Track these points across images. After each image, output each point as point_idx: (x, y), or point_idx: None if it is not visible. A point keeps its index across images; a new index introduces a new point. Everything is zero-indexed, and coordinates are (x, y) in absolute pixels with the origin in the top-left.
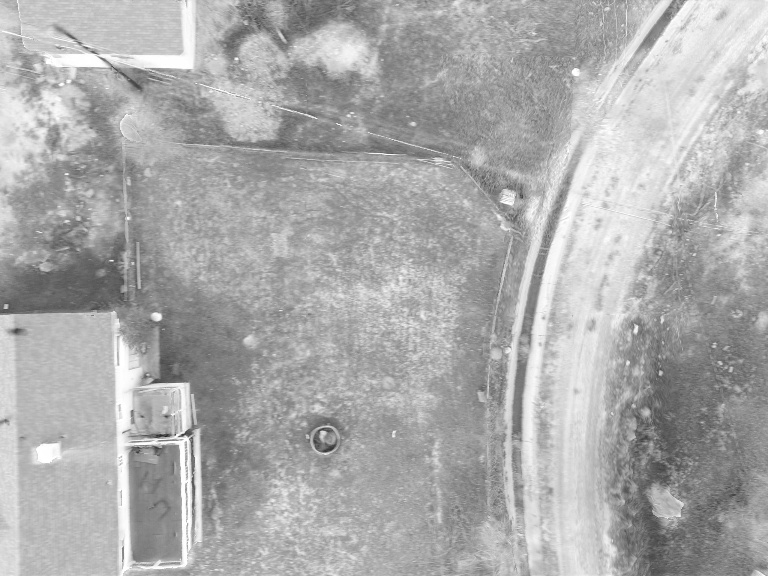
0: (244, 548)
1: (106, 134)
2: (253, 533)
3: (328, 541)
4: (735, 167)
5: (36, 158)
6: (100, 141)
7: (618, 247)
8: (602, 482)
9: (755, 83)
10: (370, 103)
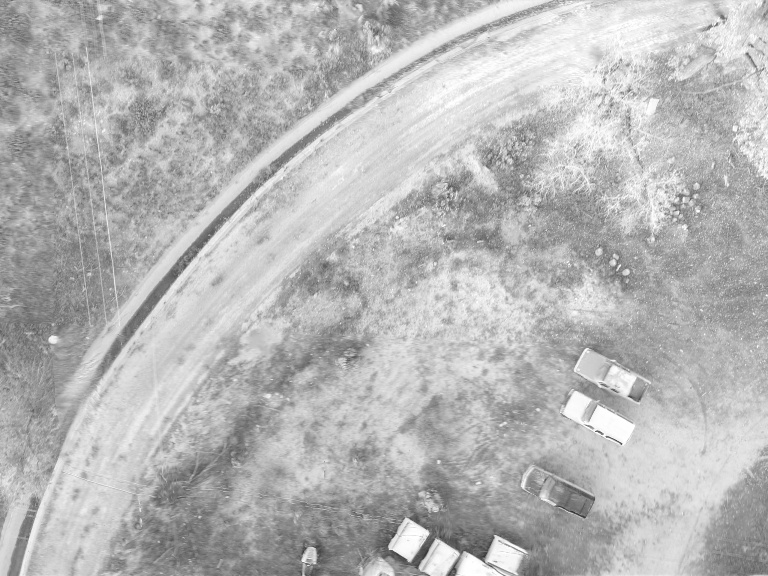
0: None
1: None
2: None
3: None
4: (243, 429)
5: None
6: None
7: (95, 519)
8: None
9: (251, 352)
10: None
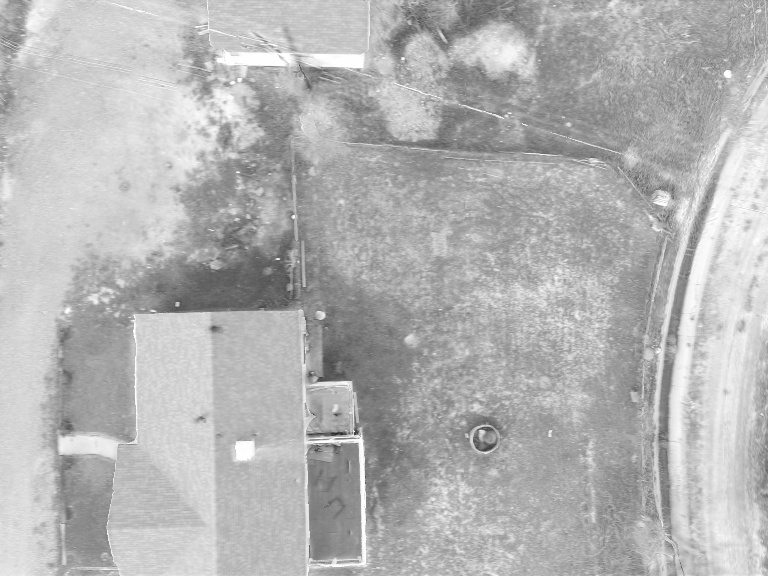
0: (405, 546)
1: (273, 133)
2: (414, 531)
3: (486, 540)
4: None
5: (208, 156)
6: (267, 139)
7: (767, 248)
8: (752, 482)
9: None
10: (527, 103)
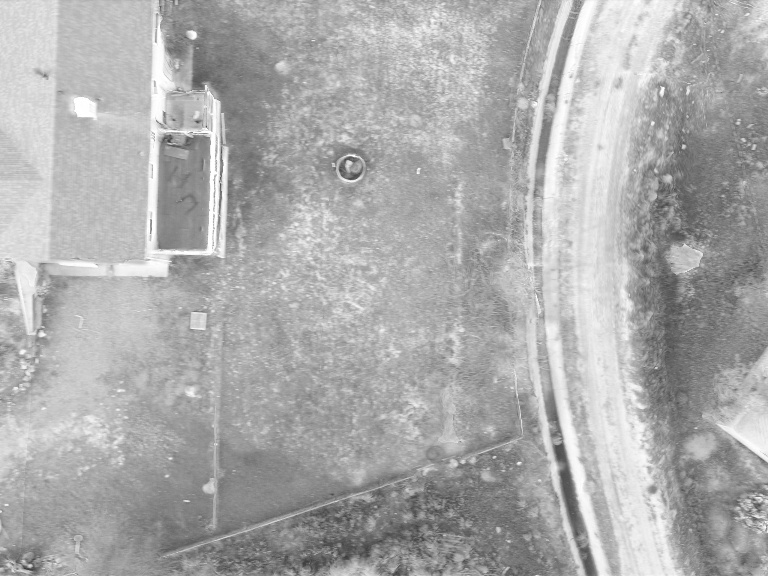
0: (266, 268)
1: None
2: (275, 254)
3: (349, 269)
4: None
5: None
6: None
7: (648, 9)
8: (622, 237)
9: None
10: None
